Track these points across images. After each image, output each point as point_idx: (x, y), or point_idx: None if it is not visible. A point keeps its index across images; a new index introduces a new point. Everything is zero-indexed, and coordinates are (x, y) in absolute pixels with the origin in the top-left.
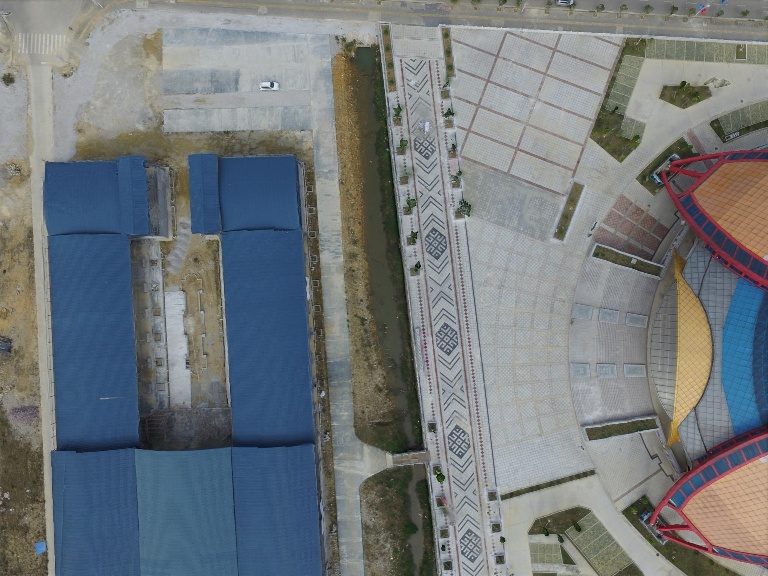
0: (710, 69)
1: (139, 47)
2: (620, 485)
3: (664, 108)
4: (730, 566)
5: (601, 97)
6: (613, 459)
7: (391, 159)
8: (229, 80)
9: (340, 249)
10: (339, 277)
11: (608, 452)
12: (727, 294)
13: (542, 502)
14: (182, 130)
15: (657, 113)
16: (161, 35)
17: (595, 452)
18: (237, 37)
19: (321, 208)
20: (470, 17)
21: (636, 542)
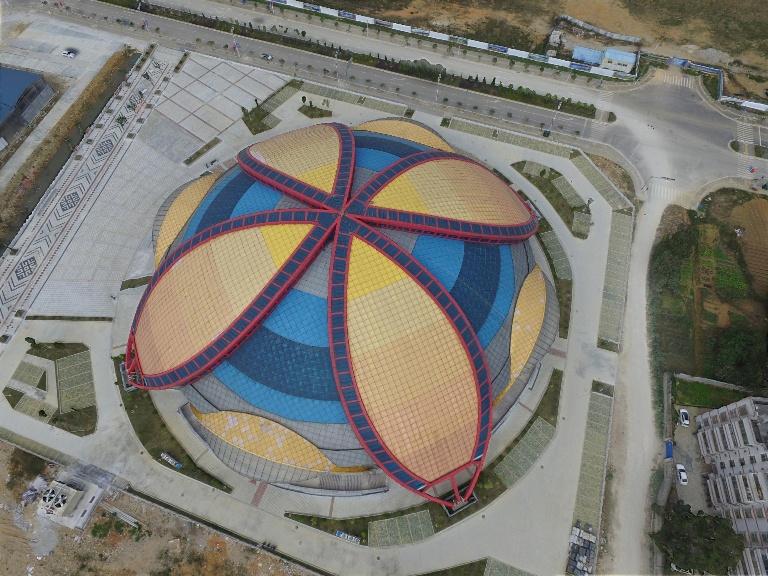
0: (338, 104)
1: (15, 26)
2: (126, 336)
3: (298, 115)
4: (178, 436)
5: (261, 102)
6: (133, 314)
7: (111, 101)
8: (50, 48)
9: (43, 137)
10: (30, 151)
11: (133, 308)
12: (227, 175)
13: (55, 331)
14: (4, 62)
15: (292, 117)
16: (31, 24)
17: (123, 305)
18: (71, 33)
19: (50, 114)
20: (208, 53)
21: (109, 388)
